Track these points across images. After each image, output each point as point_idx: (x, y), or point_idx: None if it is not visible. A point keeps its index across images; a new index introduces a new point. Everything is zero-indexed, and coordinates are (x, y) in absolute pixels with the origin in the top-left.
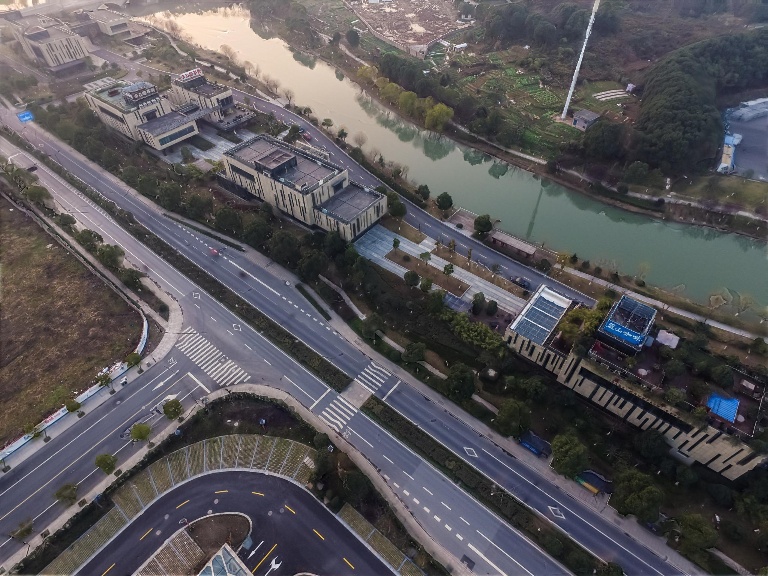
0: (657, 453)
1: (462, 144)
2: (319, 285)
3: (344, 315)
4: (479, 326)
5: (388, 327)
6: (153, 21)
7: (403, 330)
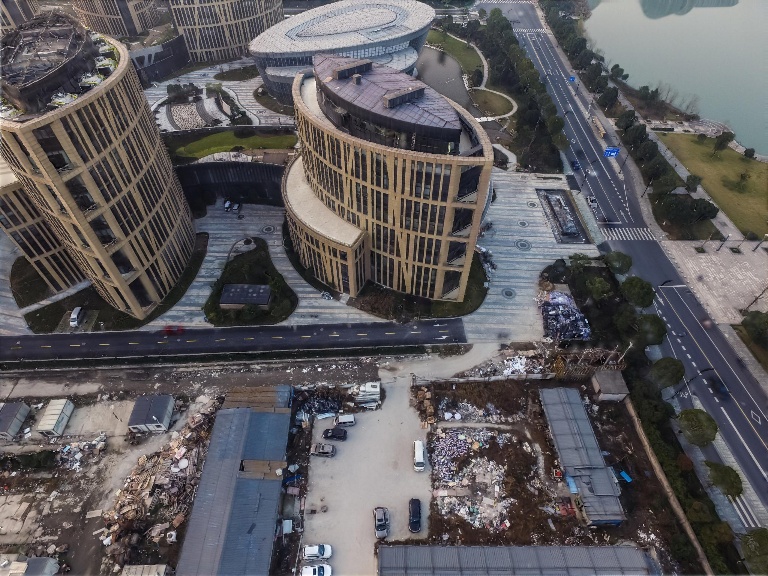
0: None
1: None
2: None
3: (51, 4)
4: None
5: (70, 3)
6: None
7: None
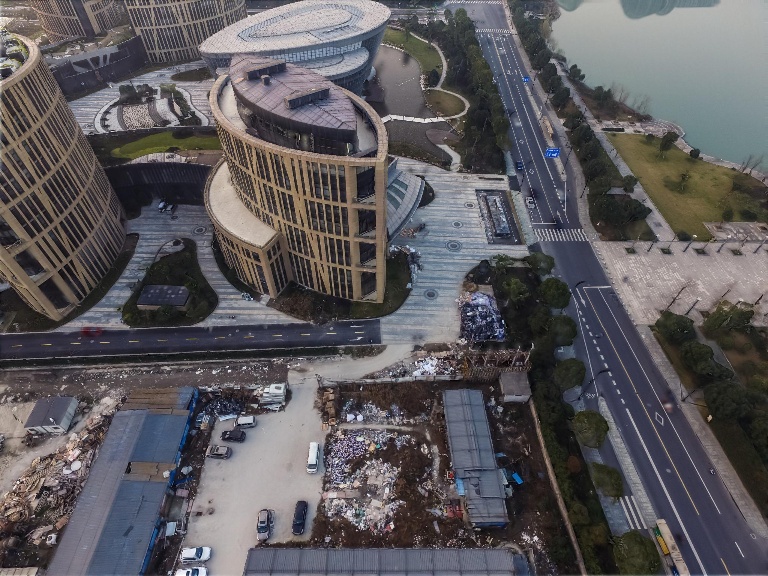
0: None
1: None
2: None
3: (21, 5)
4: None
5: None
6: None
7: None
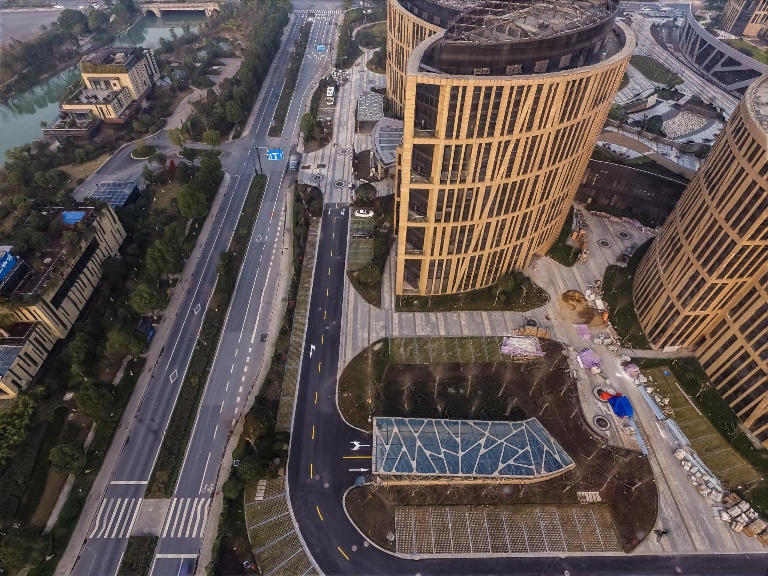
0: (122, 263)
1: None
2: None
3: None
4: None
5: None
6: None
7: None
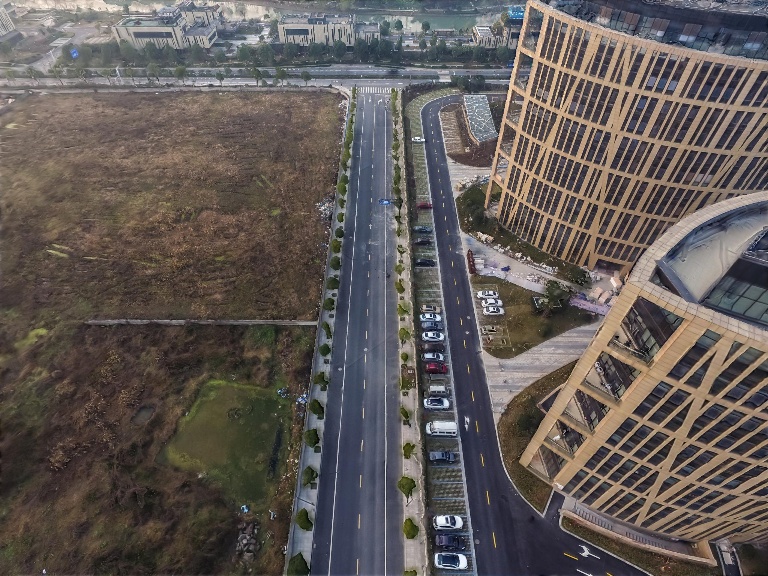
0: None
1: (366, 15)
2: (385, 62)
3: (410, 65)
4: (465, 46)
5: (430, 63)
6: (19, 3)
7: (437, 61)
